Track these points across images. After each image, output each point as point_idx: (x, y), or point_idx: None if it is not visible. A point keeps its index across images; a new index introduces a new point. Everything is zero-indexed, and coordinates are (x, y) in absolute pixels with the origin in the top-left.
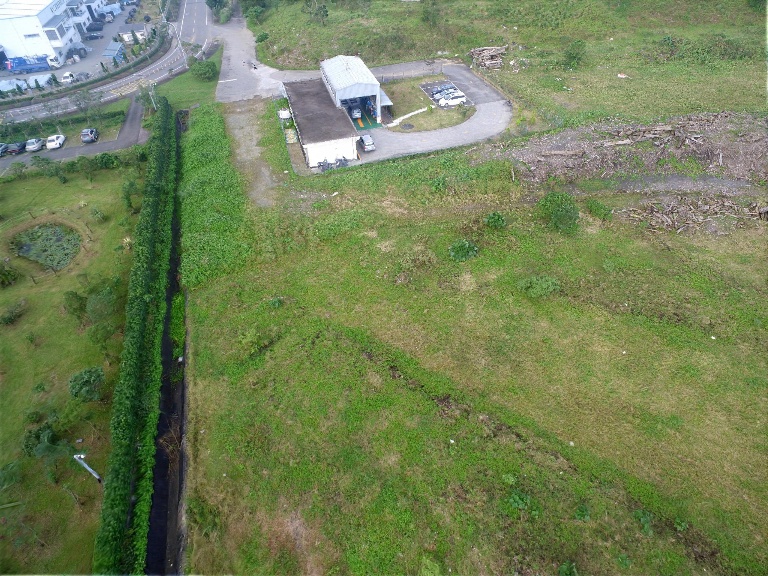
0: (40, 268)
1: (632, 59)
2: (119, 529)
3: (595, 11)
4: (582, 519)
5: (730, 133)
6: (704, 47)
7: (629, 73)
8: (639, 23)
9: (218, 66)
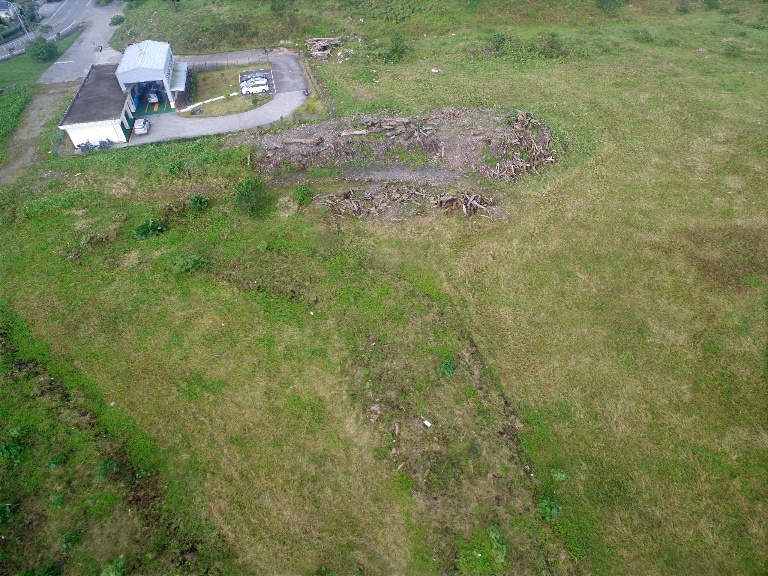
0: None
1: (457, 54)
2: None
3: (444, 6)
4: (50, 467)
5: (462, 127)
6: (527, 45)
7: (444, 68)
8: (486, 20)
9: (65, 47)
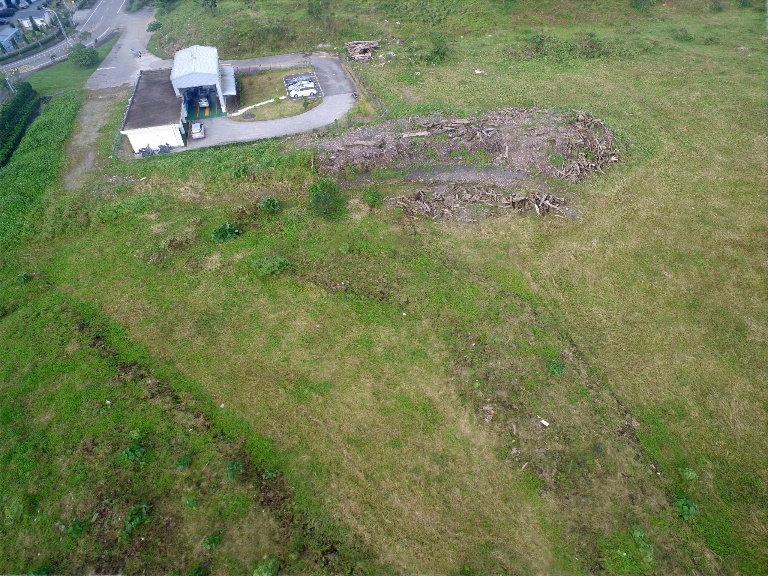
0: None
1: (498, 56)
2: None
3: (479, 8)
4: (177, 468)
5: (523, 127)
6: (568, 45)
7: (487, 69)
8: (521, 21)
9: (105, 54)
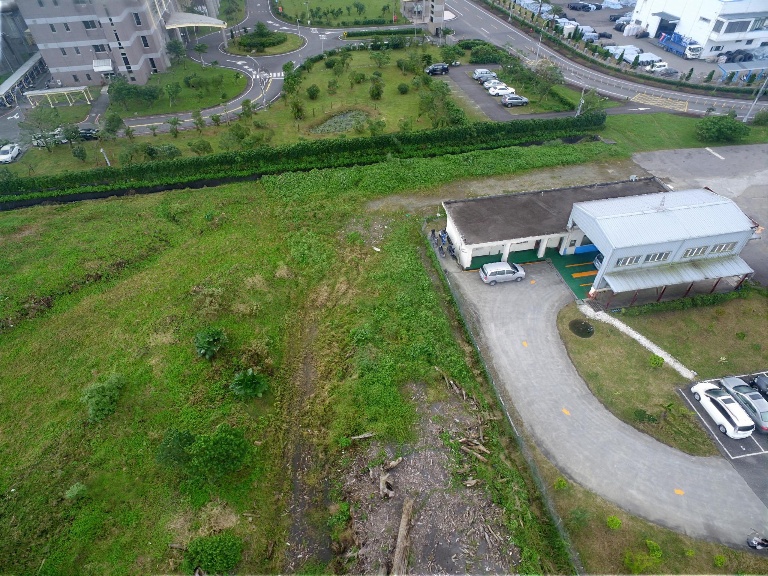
0: (313, 125)
1: None
2: (73, 178)
3: None
4: None
5: None
6: None
7: None
8: None
9: None
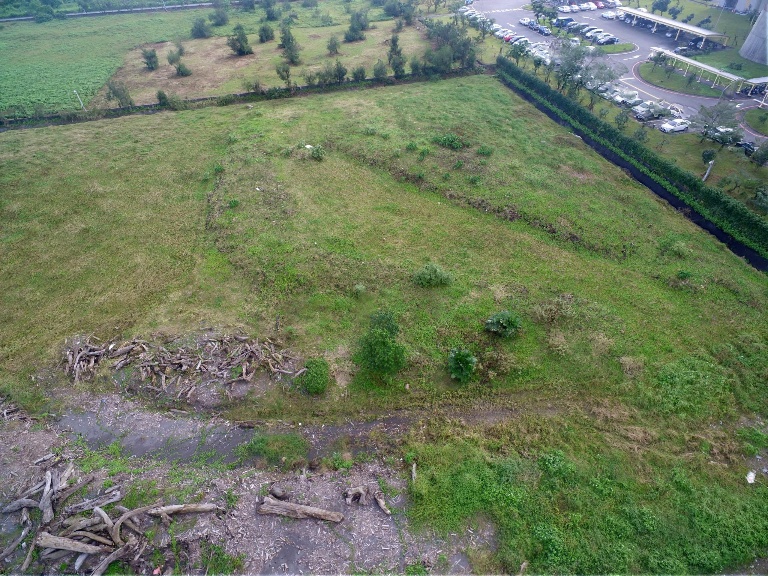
0: None
1: None
2: None
3: None
4: None
5: None
6: None
7: None
8: None
9: None
